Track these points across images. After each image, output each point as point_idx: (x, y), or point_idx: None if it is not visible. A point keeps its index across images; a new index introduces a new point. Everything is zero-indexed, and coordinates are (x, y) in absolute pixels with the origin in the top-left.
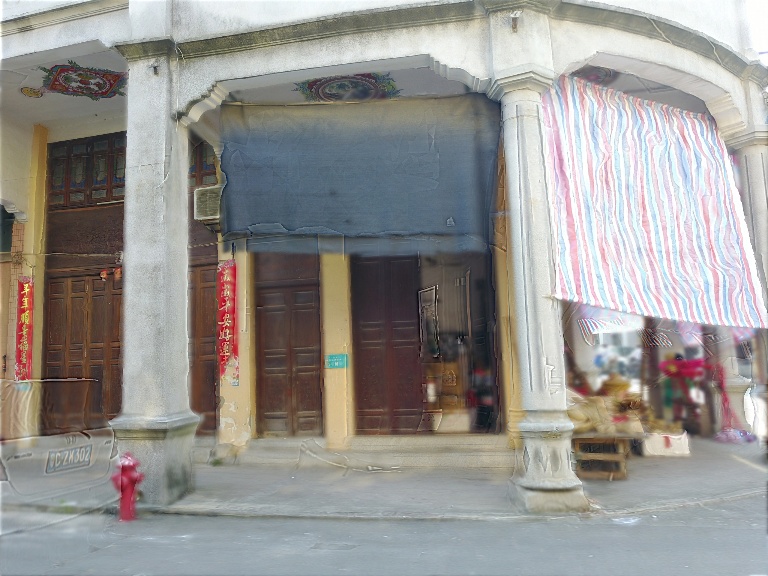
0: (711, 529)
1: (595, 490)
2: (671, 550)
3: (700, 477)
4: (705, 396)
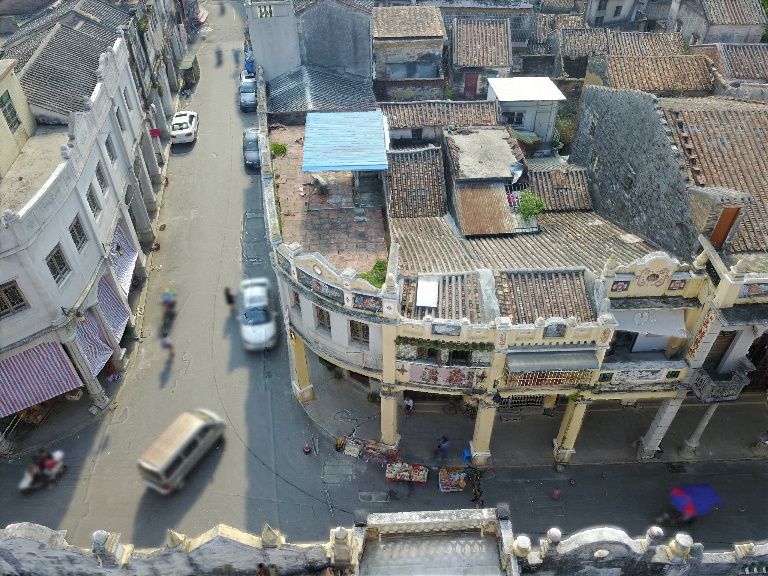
0: (22, 467)
1: (24, 437)
2: (4, 479)
3: (58, 426)
4: (106, 364)
